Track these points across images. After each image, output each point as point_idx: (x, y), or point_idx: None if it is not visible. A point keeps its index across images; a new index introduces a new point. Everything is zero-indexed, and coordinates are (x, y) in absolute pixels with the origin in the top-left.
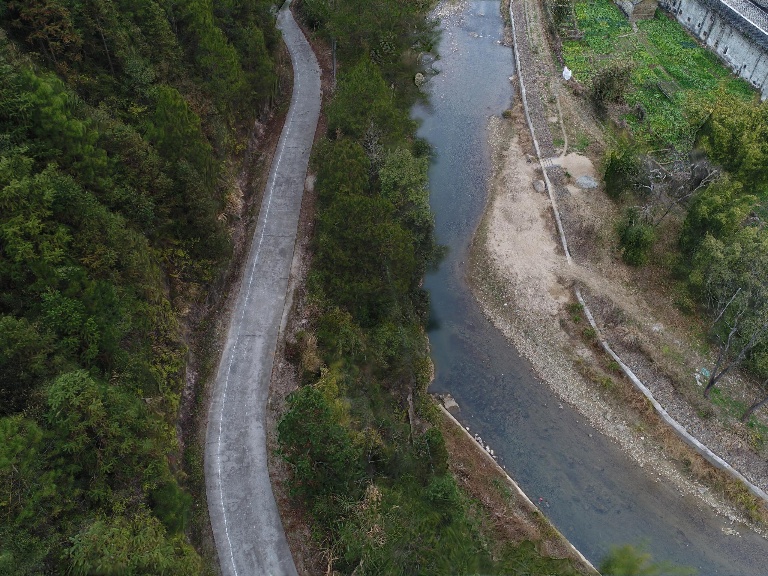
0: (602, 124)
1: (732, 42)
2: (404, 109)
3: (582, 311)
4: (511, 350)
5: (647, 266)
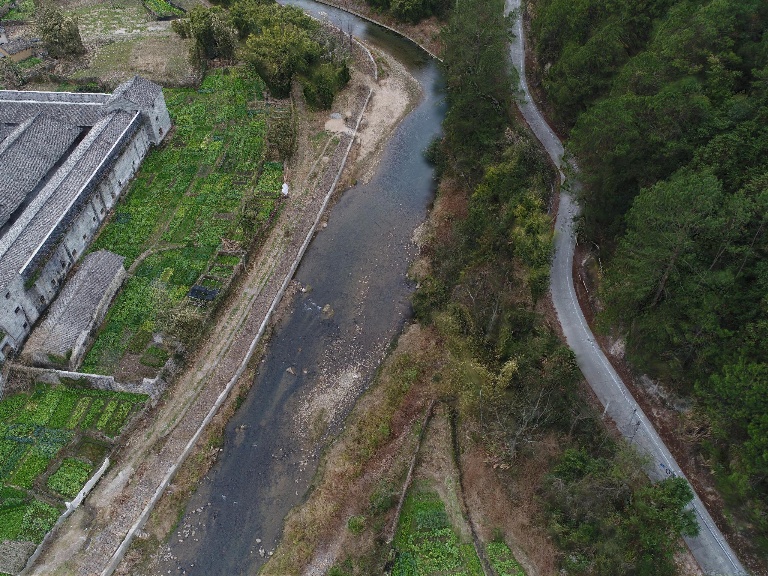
0: None
1: None
2: None
3: None
4: None
5: None
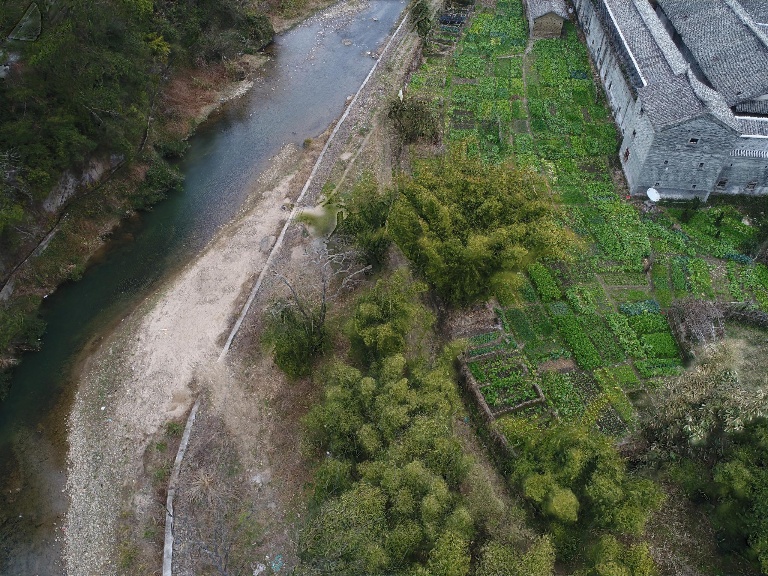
0: (397, 168)
1: (615, 76)
2: (105, 130)
3: (179, 436)
4: (59, 479)
5: (308, 379)
